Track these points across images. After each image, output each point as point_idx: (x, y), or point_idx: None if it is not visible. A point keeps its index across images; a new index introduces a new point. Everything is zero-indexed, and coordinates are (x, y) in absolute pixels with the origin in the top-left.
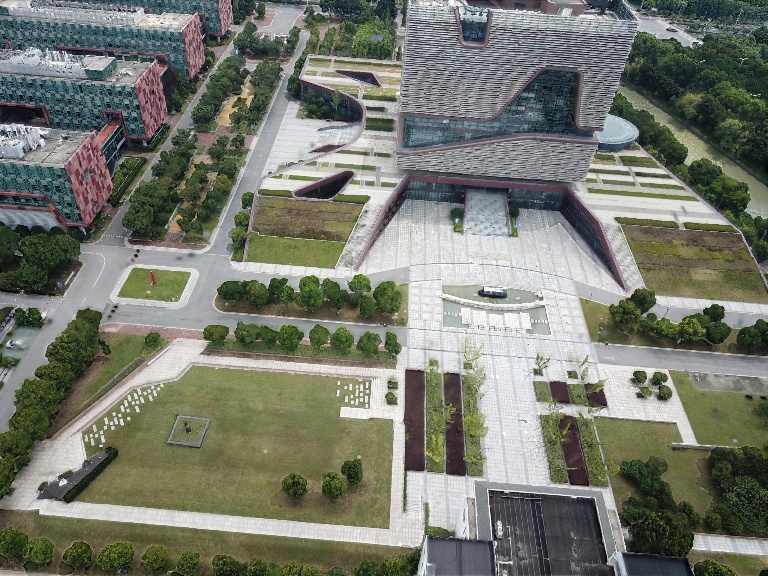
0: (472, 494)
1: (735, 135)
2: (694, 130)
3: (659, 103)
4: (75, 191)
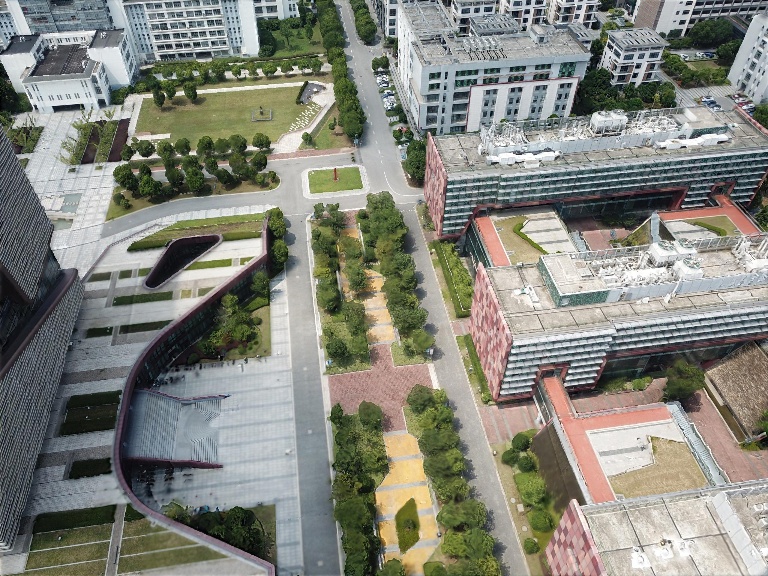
0: (94, 117)
1: None
2: None
3: None
4: None
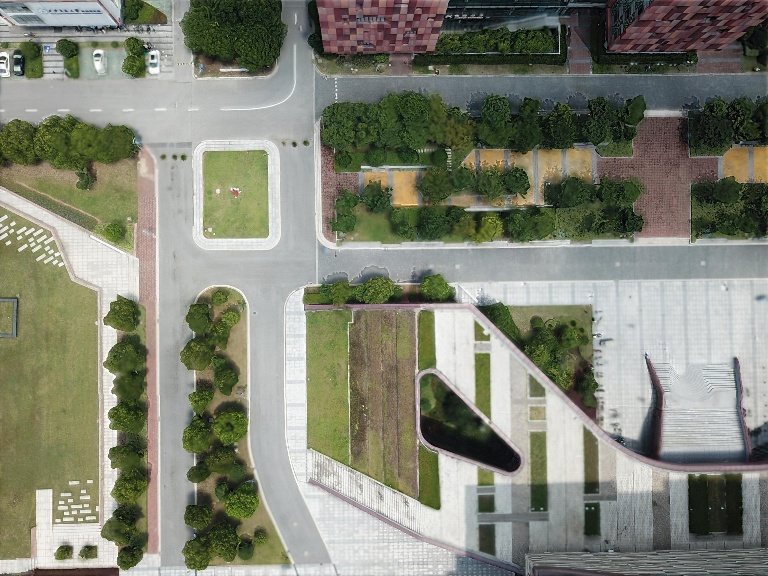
0: None
1: None
2: None
3: None
4: (321, 21)
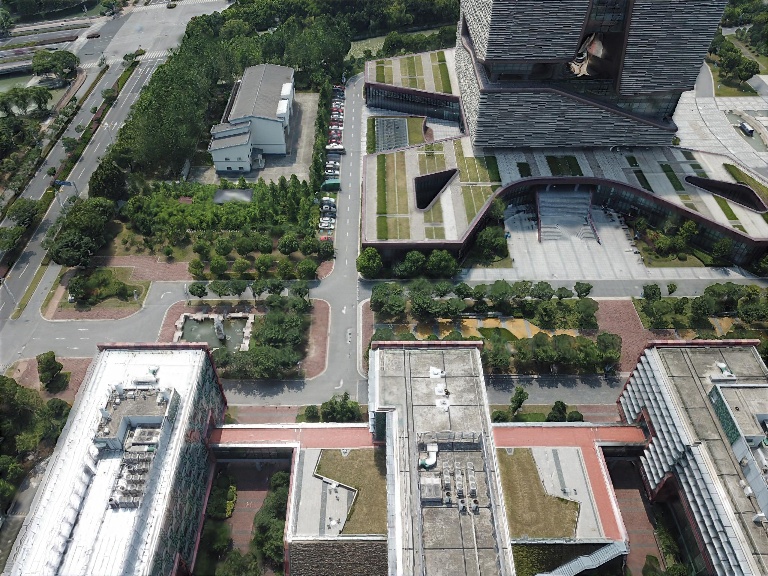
0: None
1: (455, 6)
2: (413, 29)
3: (364, 36)
4: None
